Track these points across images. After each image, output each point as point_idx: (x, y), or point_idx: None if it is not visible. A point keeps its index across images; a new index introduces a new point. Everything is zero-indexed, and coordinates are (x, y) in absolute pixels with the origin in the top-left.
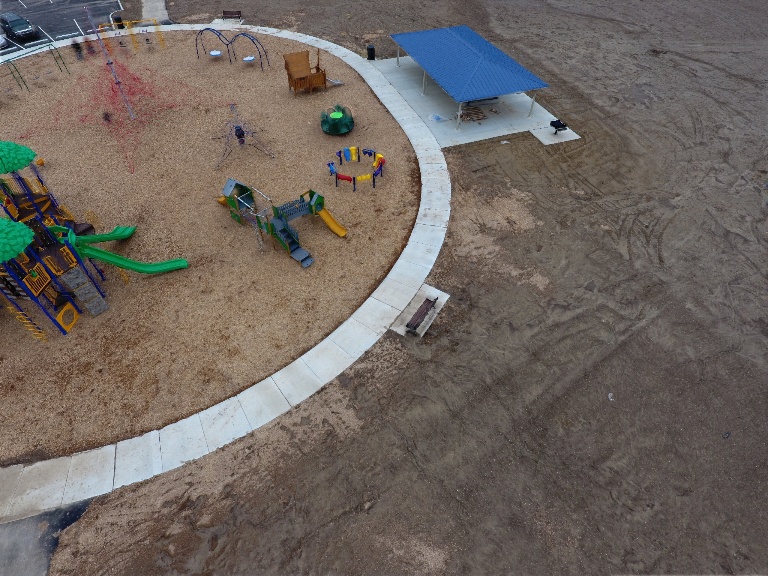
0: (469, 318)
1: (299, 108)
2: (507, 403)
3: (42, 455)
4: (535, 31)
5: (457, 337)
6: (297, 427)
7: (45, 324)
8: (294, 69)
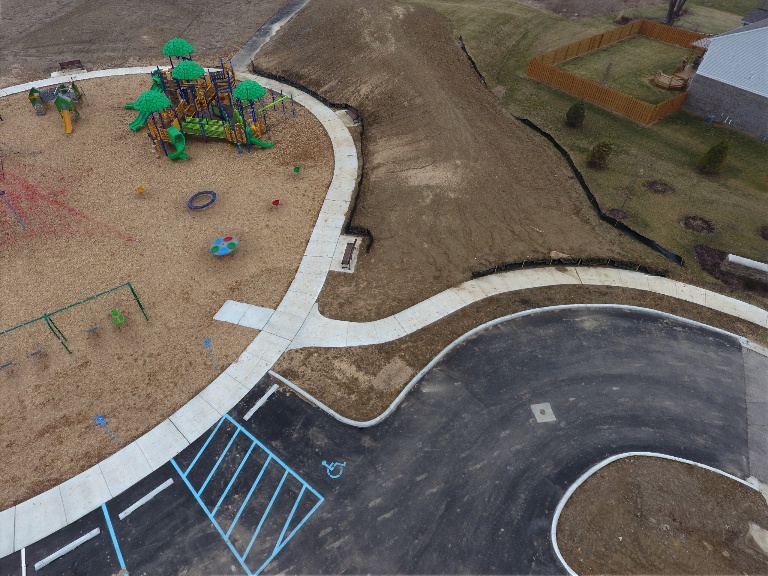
0: (59, 65)
1: None
2: (88, 47)
3: None
4: None
5: None
6: None
7: None
8: None
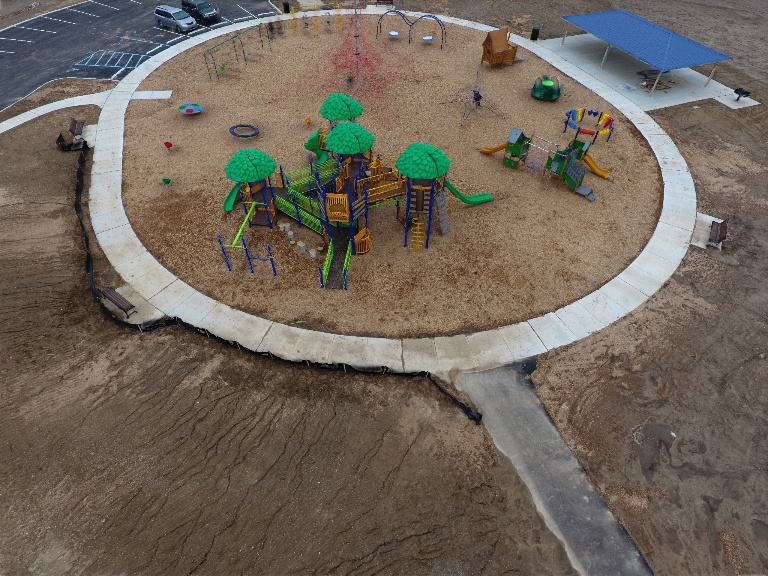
0: (753, 236)
1: (498, 79)
2: None
3: (474, 329)
4: (661, 17)
5: (752, 249)
6: (664, 309)
7: None
8: (496, 44)
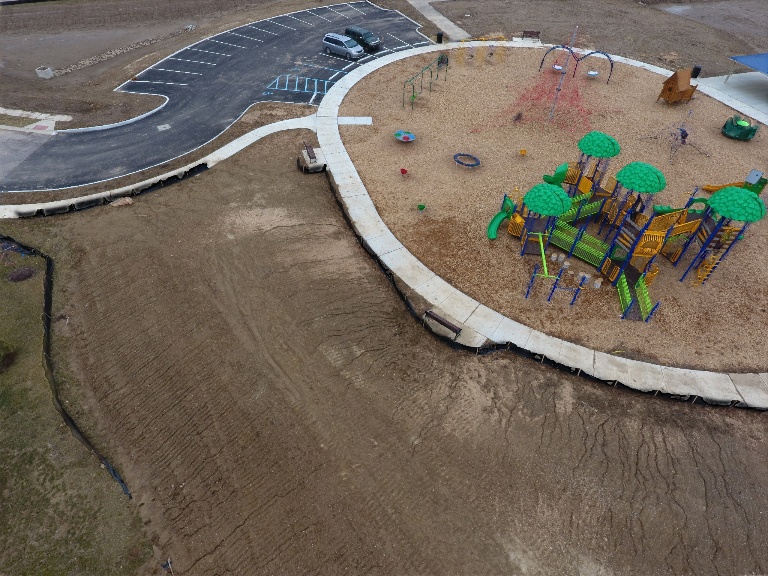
0: None
1: (680, 117)
2: None
3: None
4: None
5: None
6: None
7: (678, 276)
8: (680, 83)
